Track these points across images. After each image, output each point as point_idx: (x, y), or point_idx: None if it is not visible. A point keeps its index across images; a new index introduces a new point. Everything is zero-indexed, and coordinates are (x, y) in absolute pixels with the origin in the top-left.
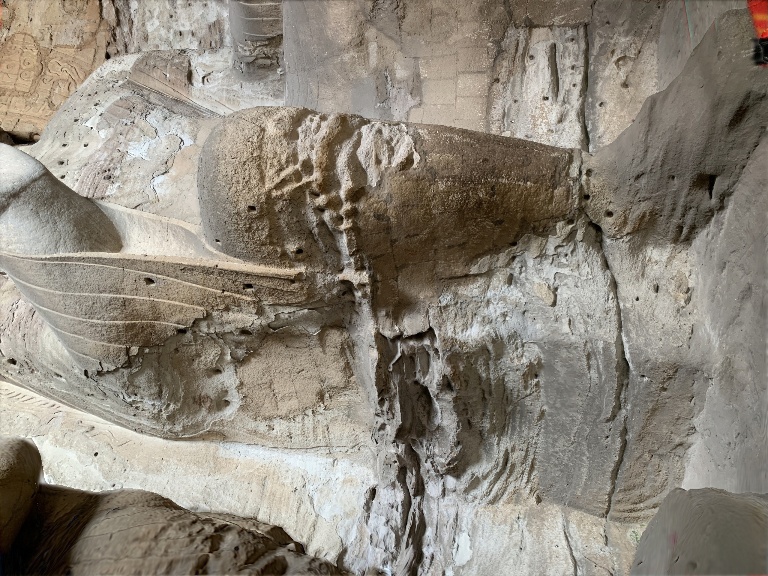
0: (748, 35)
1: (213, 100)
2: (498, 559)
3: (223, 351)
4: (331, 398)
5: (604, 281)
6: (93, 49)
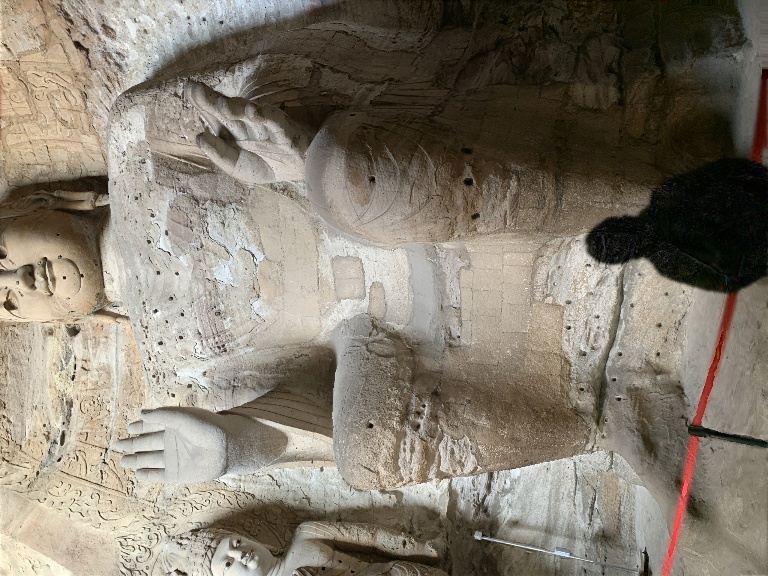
0: (691, 543)
1: None
2: (534, 478)
3: None
4: None
5: (605, 453)
6: (58, 45)
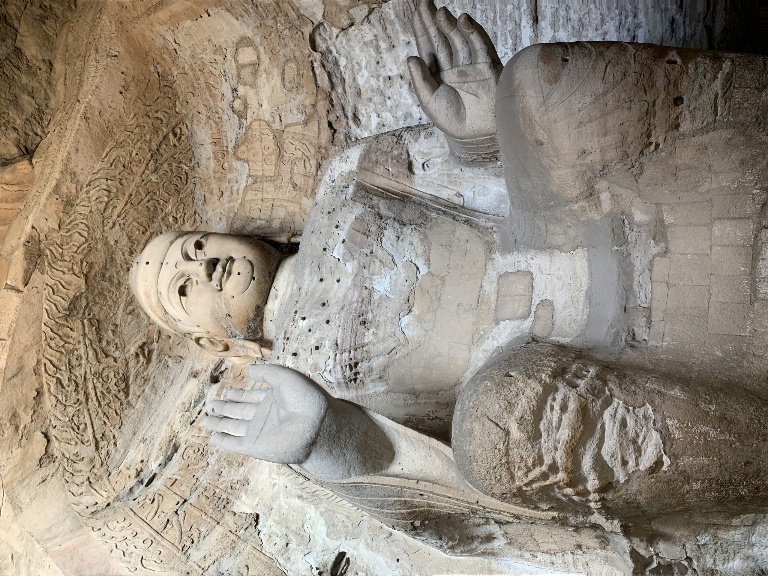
0: None
1: (435, 184)
2: None
3: (488, 520)
4: (588, 548)
5: None
6: (316, 121)
